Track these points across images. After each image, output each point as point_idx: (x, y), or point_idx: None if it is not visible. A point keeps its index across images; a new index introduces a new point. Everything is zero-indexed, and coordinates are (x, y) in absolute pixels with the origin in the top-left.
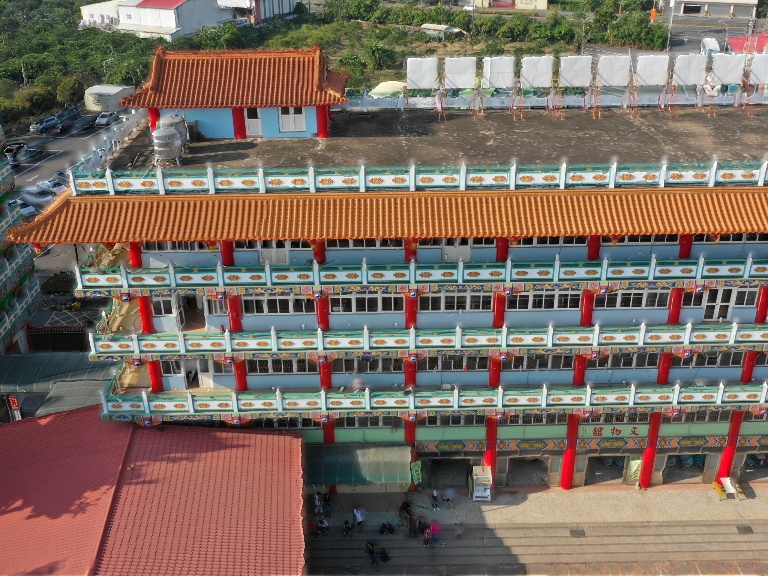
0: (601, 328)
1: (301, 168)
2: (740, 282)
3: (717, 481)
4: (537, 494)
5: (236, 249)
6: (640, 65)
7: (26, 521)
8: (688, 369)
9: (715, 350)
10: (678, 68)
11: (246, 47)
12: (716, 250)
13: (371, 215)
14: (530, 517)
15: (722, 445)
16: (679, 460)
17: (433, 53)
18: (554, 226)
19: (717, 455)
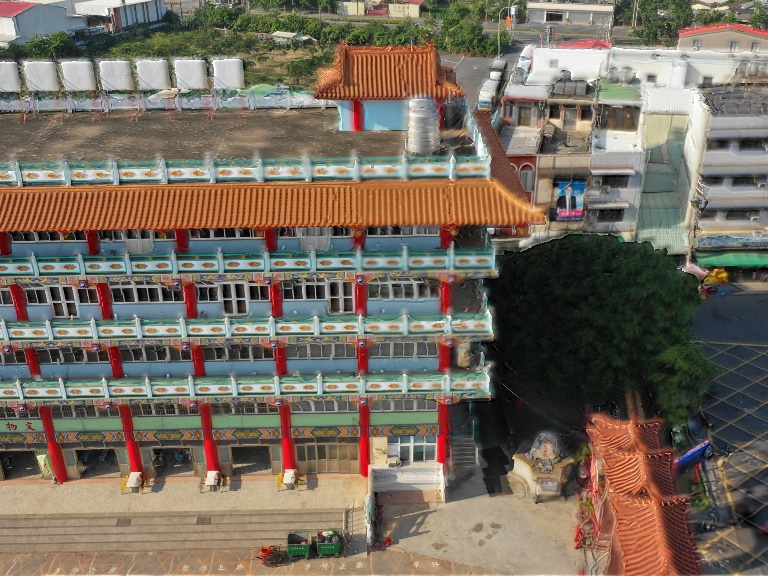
0: None
1: None
2: (30, 280)
3: (128, 475)
4: None
5: None
6: (65, 71)
7: None
8: (57, 365)
9: (34, 346)
10: (103, 74)
11: (92, 55)
12: (24, 249)
13: None
14: None
15: (121, 440)
16: (113, 455)
17: (265, 60)
18: None
19: (123, 450)
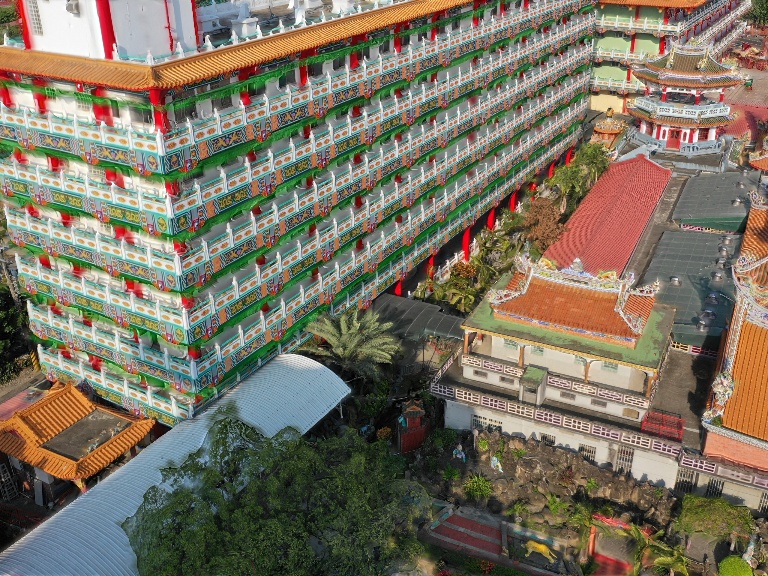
0: None
1: None
2: None
3: None
4: None
5: (676, 15)
6: None
7: None
8: None
9: None
10: None
11: None
12: None
13: None
14: None
15: None
16: None
17: None
18: None
19: None
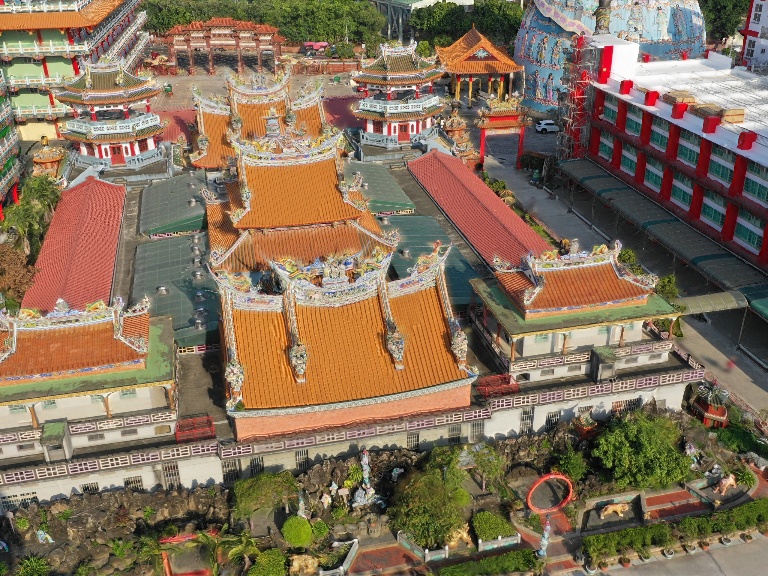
0: None
1: (65, 1)
2: None
3: None
4: None
5: None
6: None
7: None
8: None
9: None
10: None
11: None
12: None
13: (107, 3)
14: None
15: None
16: None
17: None
18: None
19: None
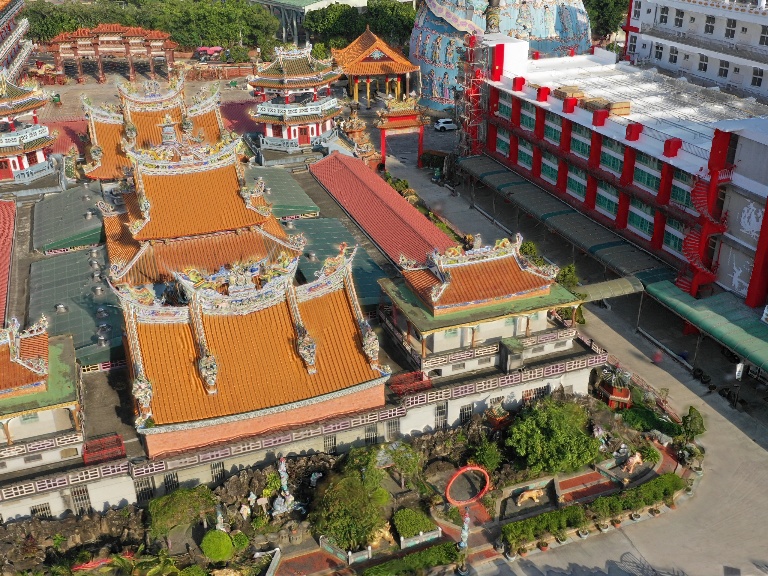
0: None
1: None
2: None
3: None
4: None
5: None
6: None
7: None
8: None
9: None
10: None
11: None
12: None
13: None
14: None
15: None
16: None
17: None
18: (0, 5)
19: None
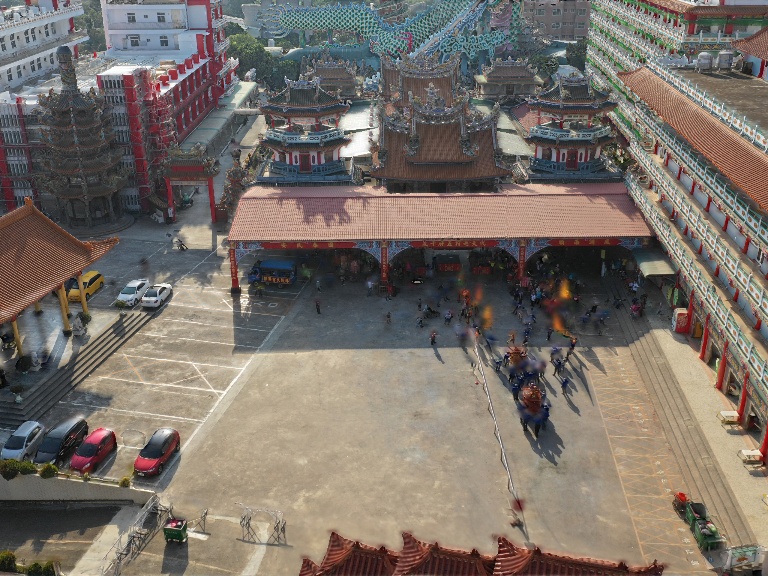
0: (700, 217)
1: None
2: None
3: None
4: (690, 347)
5: None
6: None
7: (564, 189)
8: None
9: None
10: None
11: None
12: None
13: None
14: (665, 343)
15: None
16: None
17: None
18: None
19: None
